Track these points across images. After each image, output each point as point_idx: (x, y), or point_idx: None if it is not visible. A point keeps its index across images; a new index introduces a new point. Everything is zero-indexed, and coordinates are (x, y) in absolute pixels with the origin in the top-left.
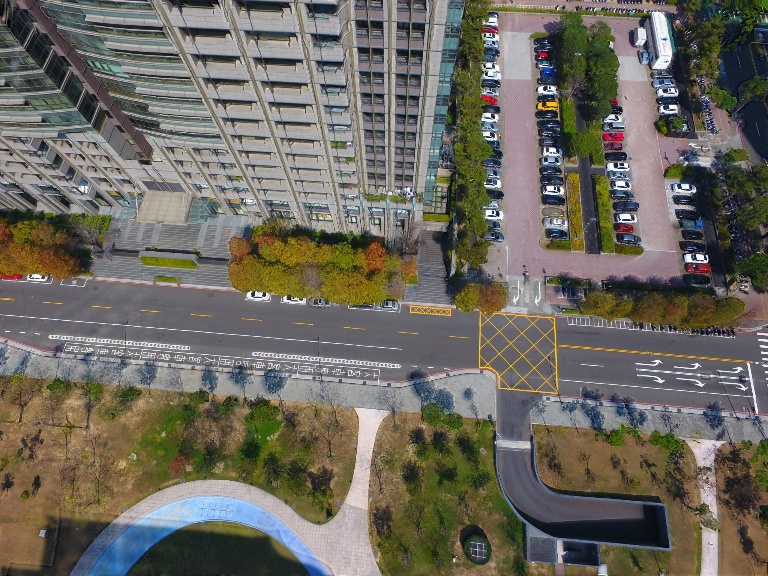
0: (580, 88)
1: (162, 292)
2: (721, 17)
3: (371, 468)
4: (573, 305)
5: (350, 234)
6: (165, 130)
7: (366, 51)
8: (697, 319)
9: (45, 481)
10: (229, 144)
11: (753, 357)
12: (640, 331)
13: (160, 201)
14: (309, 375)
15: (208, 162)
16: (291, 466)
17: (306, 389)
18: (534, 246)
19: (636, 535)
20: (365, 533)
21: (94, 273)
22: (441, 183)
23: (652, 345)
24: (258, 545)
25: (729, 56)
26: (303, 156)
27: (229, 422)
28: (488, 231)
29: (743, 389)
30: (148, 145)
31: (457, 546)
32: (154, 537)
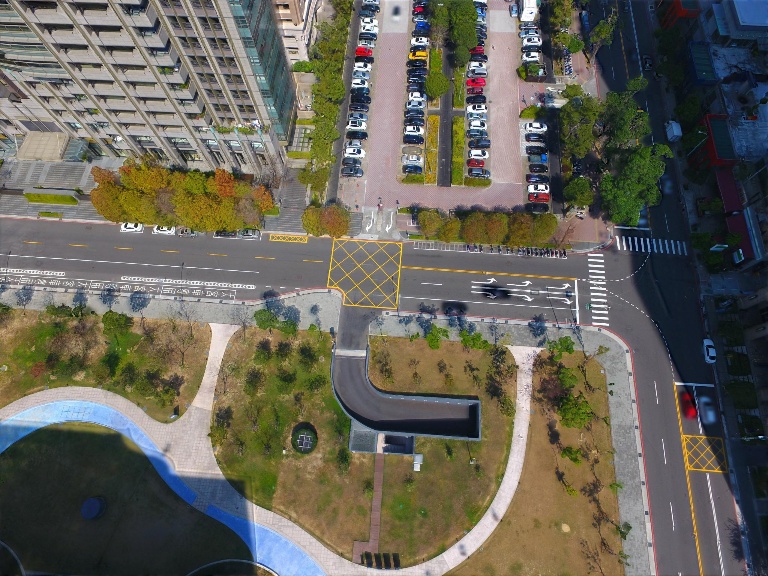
0: (443, 36)
1: (44, 226)
2: None
3: (219, 375)
4: (420, 232)
5: None
6: (13, 61)
7: None
8: (516, 235)
9: None
10: (69, 72)
11: (581, 275)
12: (480, 254)
13: (39, 140)
14: (171, 296)
15: (69, 97)
16: (146, 374)
17: (167, 308)
18: (391, 180)
19: (454, 430)
20: (207, 430)
21: None
22: (309, 125)
23: (489, 266)
24: (109, 441)
25: (595, 8)
26: (143, 85)
27: (94, 337)
28: None
29: (568, 303)
30: None
31: (289, 440)
32: (16, 436)
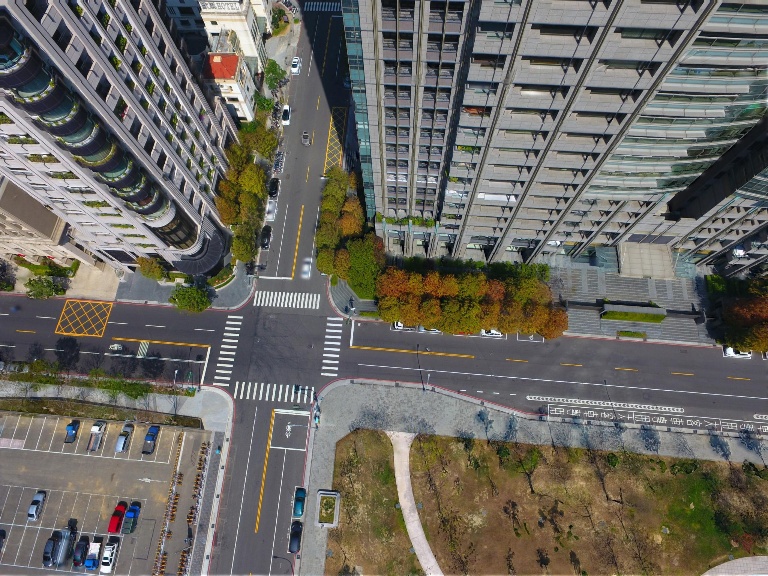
0: None
1: (630, 348)
2: None
3: None
4: None
5: None
6: None
7: None
8: None
9: (583, 557)
10: None
11: None
12: None
13: (640, 254)
14: None
15: None
16: None
17: None
18: None
19: None
20: None
21: None
22: None
23: None
24: None
25: None
26: None
27: (757, 492)
28: None
29: None
30: None
31: None
32: None
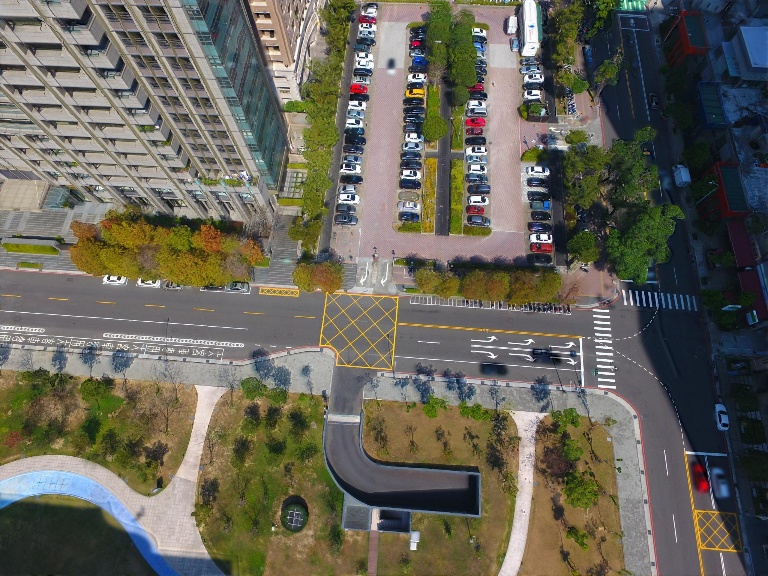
0: (440, 75)
1: (23, 277)
2: (579, 3)
3: (205, 442)
4: (417, 285)
5: (207, 219)
6: None
7: (126, 35)
8: (518, 295)
9: None
10: (44, 129)
11: (586, 332)
12: (479, 309)
13: (18, 189)
14: (155, 355)
15: (46, 149)
16: (128, 441)
17: (150, 368)
18: (387, 229)
19: (453, 504)
20: (192, 504)
21: None
22: (301, 169)
23: (489, 322)
24: (88, 516)
25: (599, 42)
26: (123, 141)
27: (74, 400)
28: (343, 215)
29: (572, 363)
30: None
31: (278, 515)
32: None
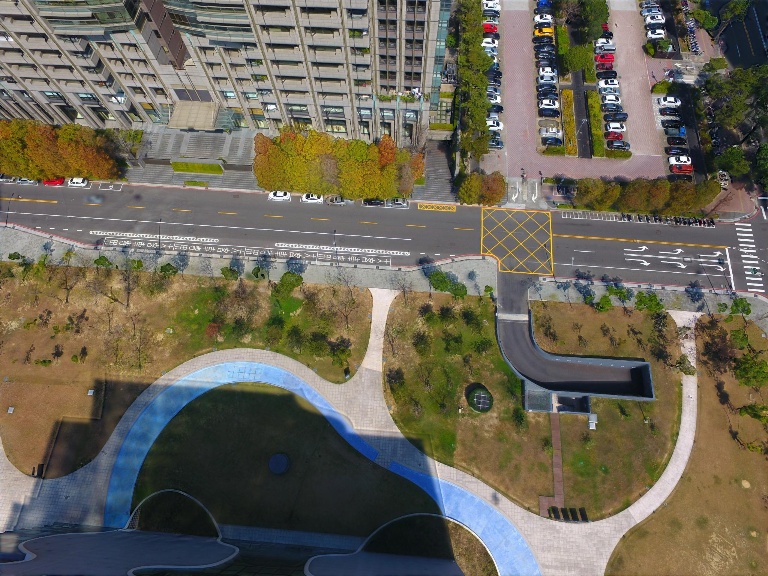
0: (573, 12)
1: (192, 194)
2: None
3: (384, 338)
4: (567, 201)
5: None
6: (201, 24)
7: None
8: (678, 201)
9: (91, 351)
10: (258, 35)
11: (731, 243)
12: (628, 223)
13: (190, 109)
14: (327, 262)
15: (236, 64)
16: (312, 336)
17: (325, 273)
18: (531, 152)
19: (623, 391)
20: (380, 390)
21: (129, 179)
22: (446, 98)
23: (639, 234)
24: (284, 401)
25: None
26: (323, 50)
27: (255, 301)
28: None
29: (721, 270)
30: (180, 56)
31: (462, 400)
32: (191, 395)
